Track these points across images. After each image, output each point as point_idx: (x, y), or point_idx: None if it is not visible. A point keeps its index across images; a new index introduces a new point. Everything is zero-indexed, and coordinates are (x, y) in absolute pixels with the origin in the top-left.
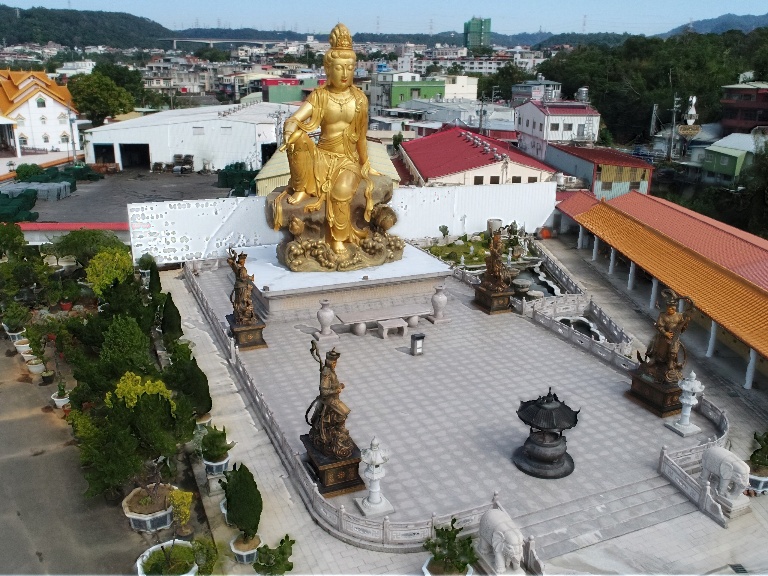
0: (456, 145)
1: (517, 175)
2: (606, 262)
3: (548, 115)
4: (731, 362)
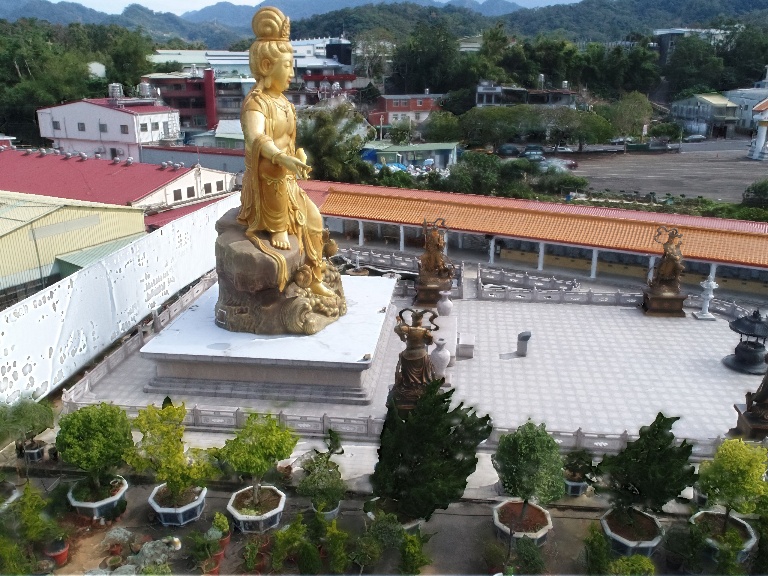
0: (30, 162)
1: (207, 182)
2: (373, 244)
3: (136, 115)
4: (608, 276)
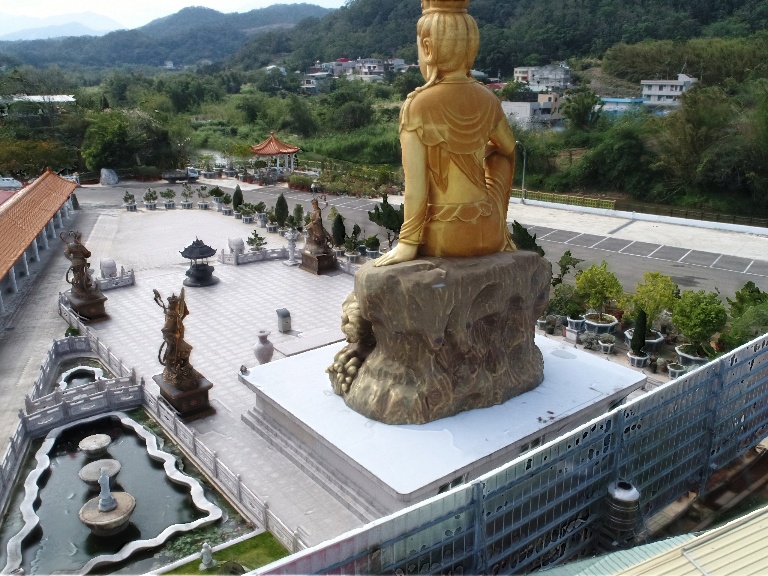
0: None
1: None
2: None
3: None
4: None
